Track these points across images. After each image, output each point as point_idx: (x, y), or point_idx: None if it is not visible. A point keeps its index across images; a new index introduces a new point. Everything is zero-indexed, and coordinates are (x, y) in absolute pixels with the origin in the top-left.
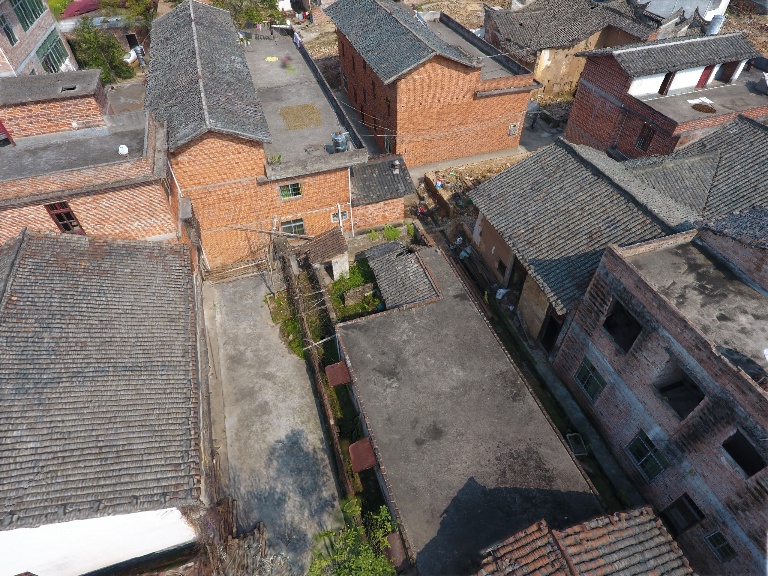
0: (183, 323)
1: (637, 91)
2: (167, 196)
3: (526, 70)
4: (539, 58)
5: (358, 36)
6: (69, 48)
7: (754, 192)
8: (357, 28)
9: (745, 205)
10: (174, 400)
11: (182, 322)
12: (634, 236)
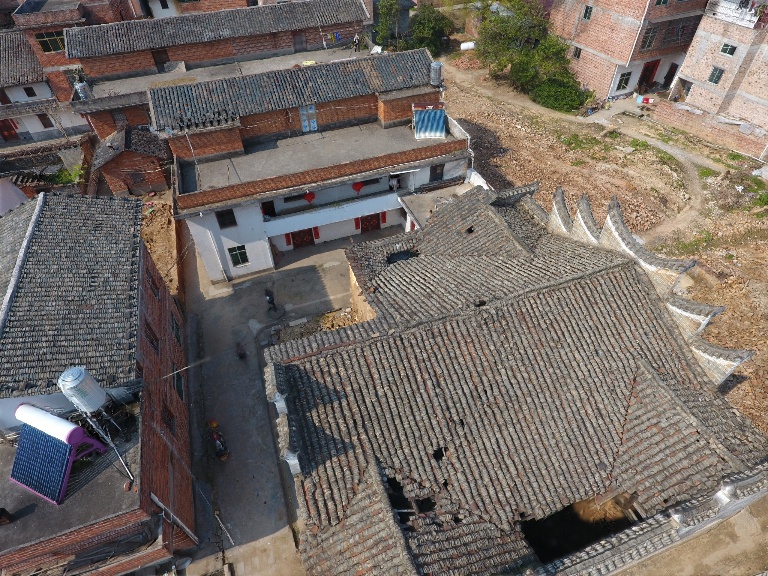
0: None
1: None
2: (50, 50)
3: (195, 192)
4: None
5: None
6: (371, 7)
7: None
8: None
9: None
10: None
11: None
12: None
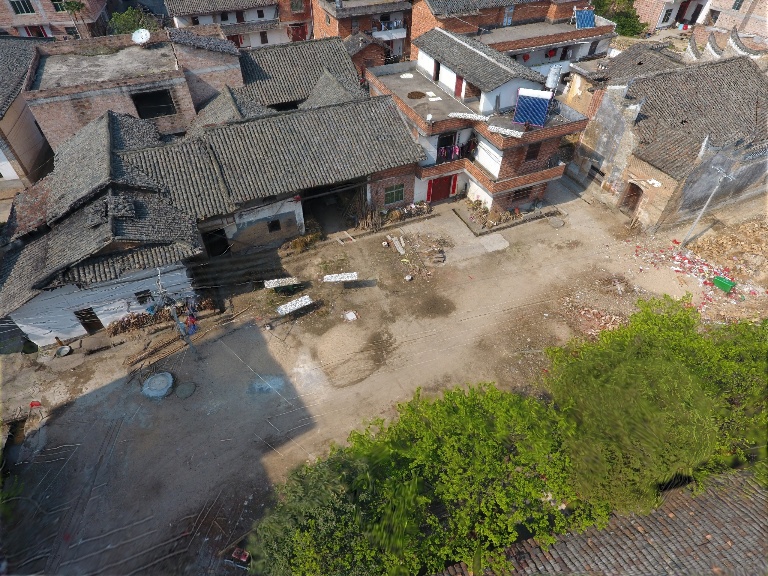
0: (235, 7)
1: None
2: None
3: None
4: (573, 81)
5: None
6: None
7: None
8: None
9: None
10: (201, 8)
11: (235, 6)
12: None
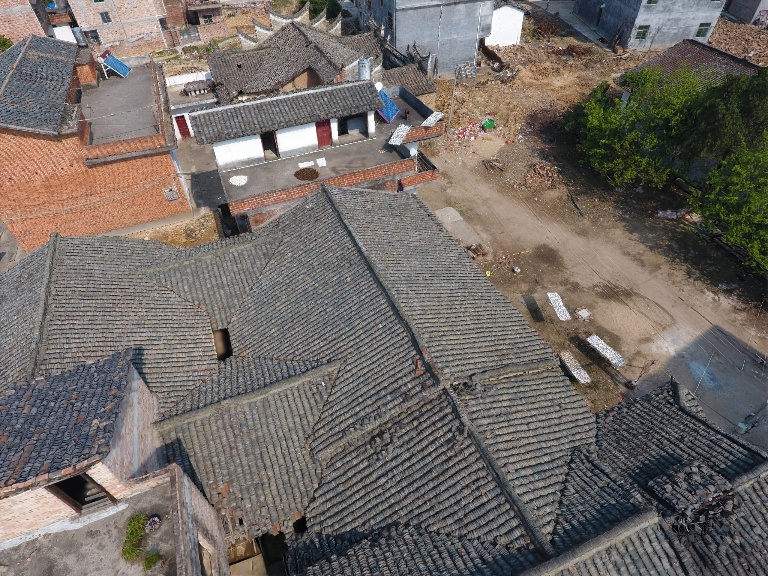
0: None
1: (231, 157)
2: None
3: None
4: None
5: None
6: None
7: (284, 291)
8: None
9: (268, 309)
10: None
11: None
12: (3, 390)
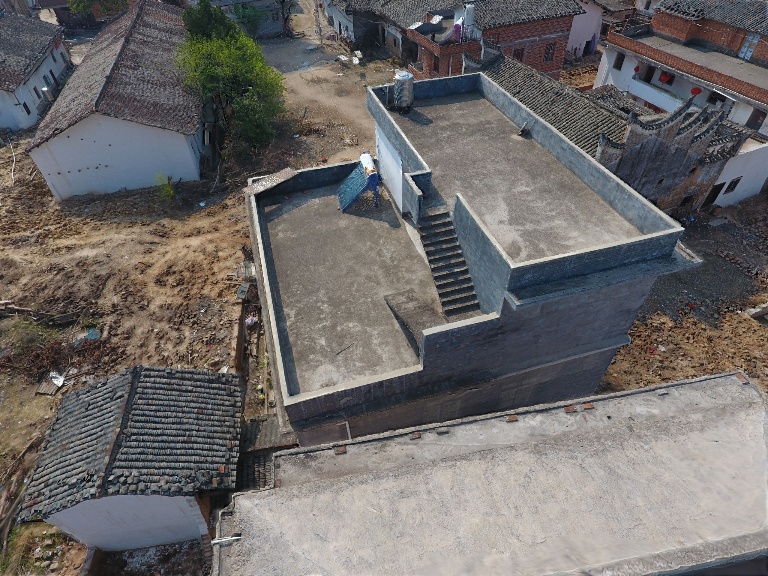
0: None
1: None
2: None
3: None
4: None
5: None
6: None
7: None
8: None
9: None
10: None
11: None
12: None
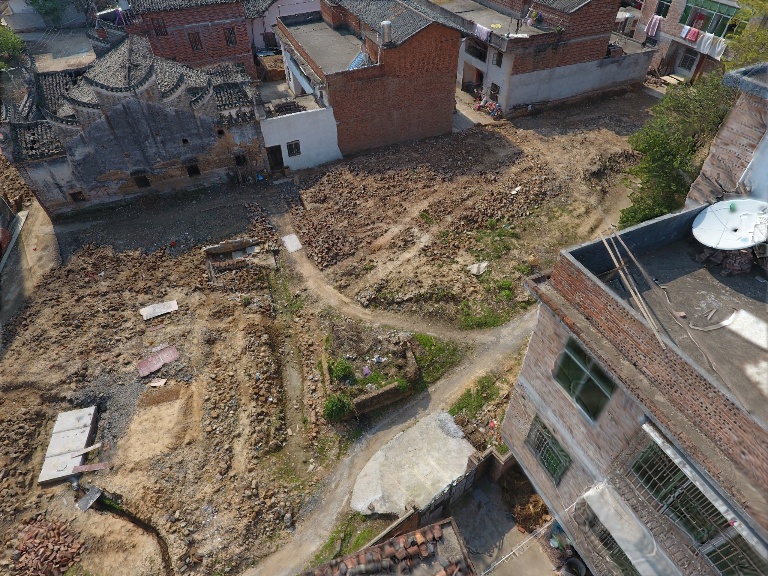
0: None
1: None
2: None
3: None
4: None
5: (416, 4)
6: None
7: None
8: (420, 7)
9: None
10: None
11: None
12: None
